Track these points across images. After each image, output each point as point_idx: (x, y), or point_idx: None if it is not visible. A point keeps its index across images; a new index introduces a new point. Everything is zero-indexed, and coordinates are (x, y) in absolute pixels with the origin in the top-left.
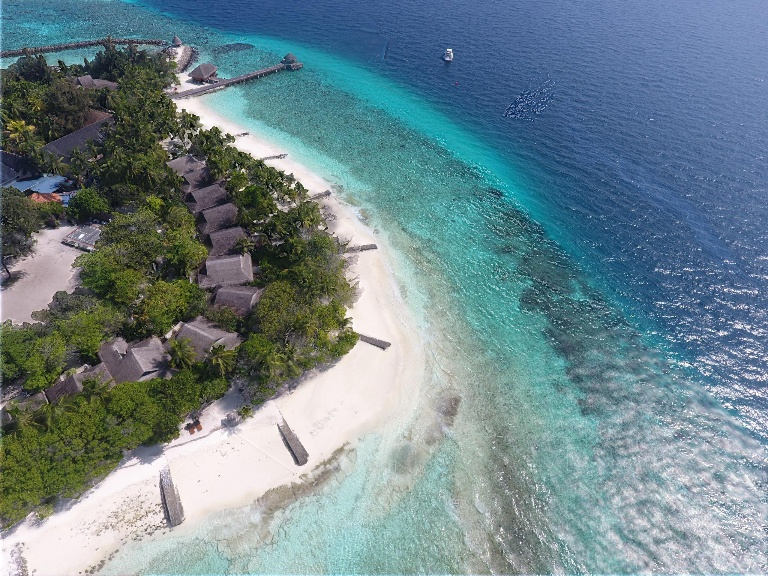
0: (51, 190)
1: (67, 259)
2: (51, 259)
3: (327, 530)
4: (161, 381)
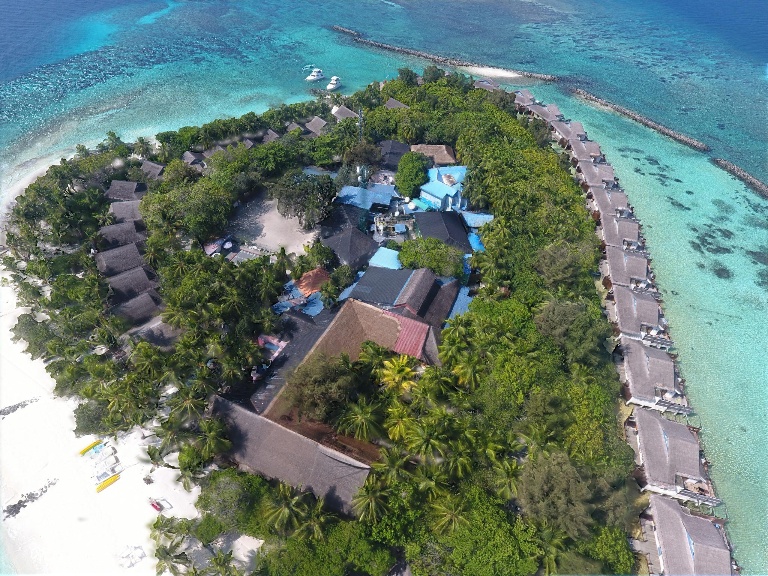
0: (313, 297)
1: (273, 242)
2: (286, 242)
3: (121, 138)
4: (174, 137)
